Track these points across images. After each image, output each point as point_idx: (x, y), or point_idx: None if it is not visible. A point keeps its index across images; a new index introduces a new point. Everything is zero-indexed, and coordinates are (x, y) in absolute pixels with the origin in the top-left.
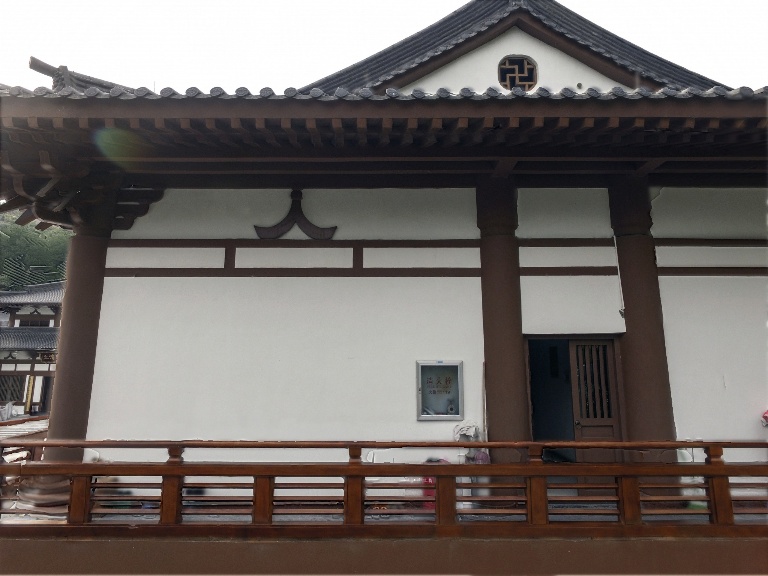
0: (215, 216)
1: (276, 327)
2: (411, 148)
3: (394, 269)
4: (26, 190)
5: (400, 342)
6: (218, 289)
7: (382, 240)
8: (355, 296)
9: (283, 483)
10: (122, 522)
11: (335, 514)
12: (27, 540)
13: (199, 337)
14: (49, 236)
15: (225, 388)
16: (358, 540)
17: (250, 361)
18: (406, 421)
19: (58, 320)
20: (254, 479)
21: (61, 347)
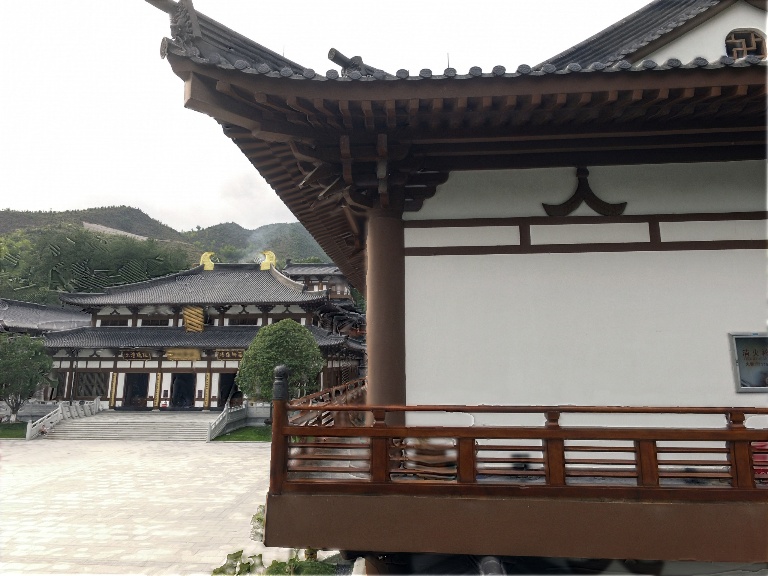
0: (502, 196)
1: (579, 301)
2: (750, 117)
3: (693, 242)
4: (352, 173)
5: (708, 315)
6: (517, 266)
7: (677, 214)
8: (657, 270)
9: (664, 447)
10: (511, 482)
11: (722, 478)
12: (425, 497)
13: (503, 312)
14: (109, 241)
15: (535, 361)
16: (755, 503)
17: (557, 335)
18: (724, 393)
19: (136, 320)
20: (636, 443)
21: (377, 322)
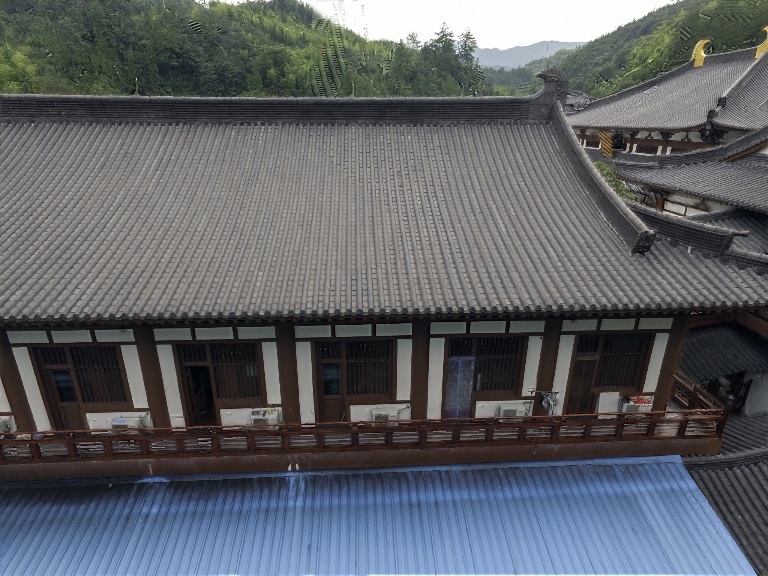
0: None
1: None
2: None
3: None
4: None
5: None
6: None
7: None
8: None
9: None
10: None
11: None
12: None
13: None
14: (766, 0)
15: None
16: None
17: None
18: None
19: (583, 140)
20: None
21: None
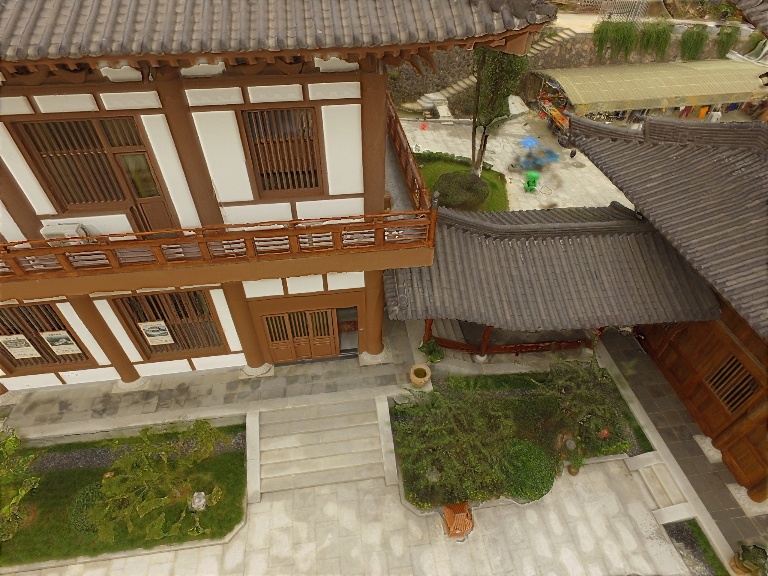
0: None
1: None
2: None
3: None
4: None
5: None
6: None
7: None
8: None
9: None
10: None
11: None
12: None
13: None
14: None
15: None
16: None
17: None
18: None
19: None
20: None
21: None
